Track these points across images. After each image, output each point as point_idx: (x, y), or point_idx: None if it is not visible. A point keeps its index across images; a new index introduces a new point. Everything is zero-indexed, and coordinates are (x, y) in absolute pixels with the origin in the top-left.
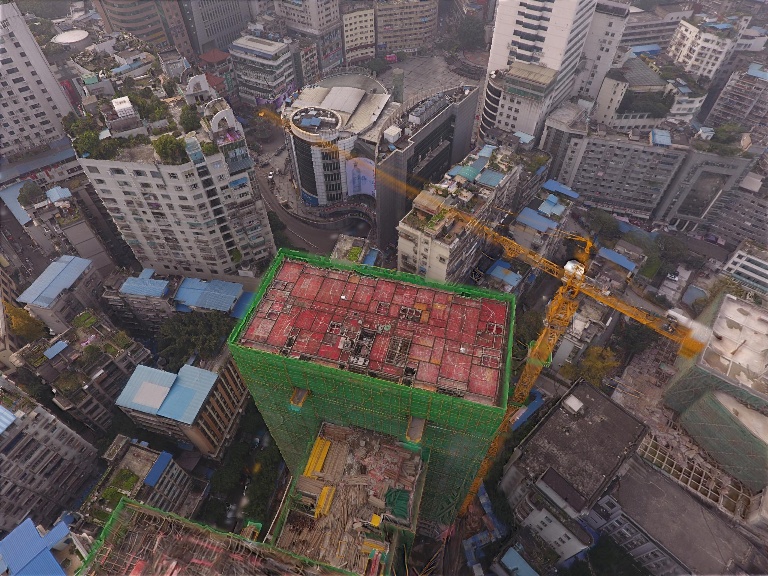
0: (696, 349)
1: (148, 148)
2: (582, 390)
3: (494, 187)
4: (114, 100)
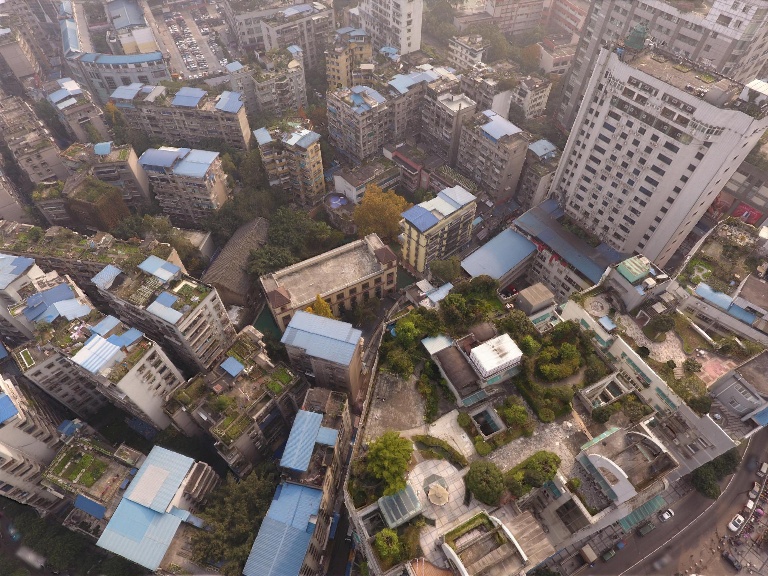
0: None
1: (416, 417)
2: None
3: None
4: (506, 337)
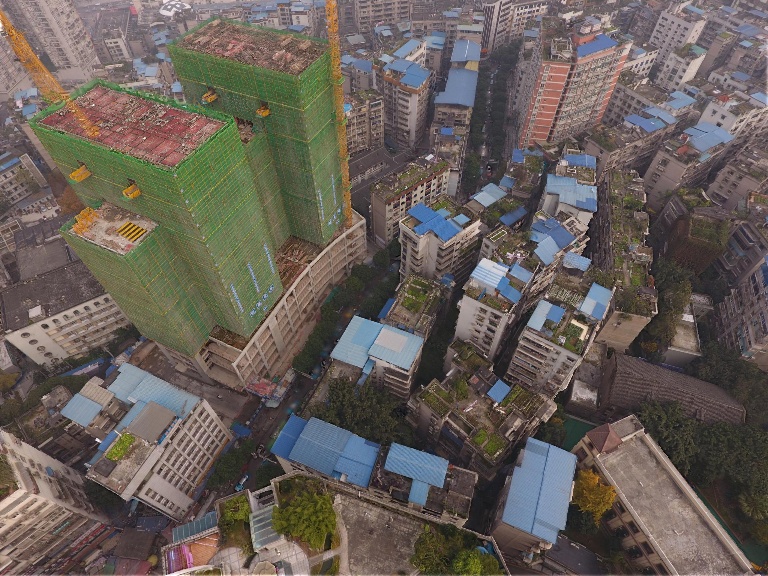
0: None
1: (361, 565)
2: (17, 326)
3: None
4: None
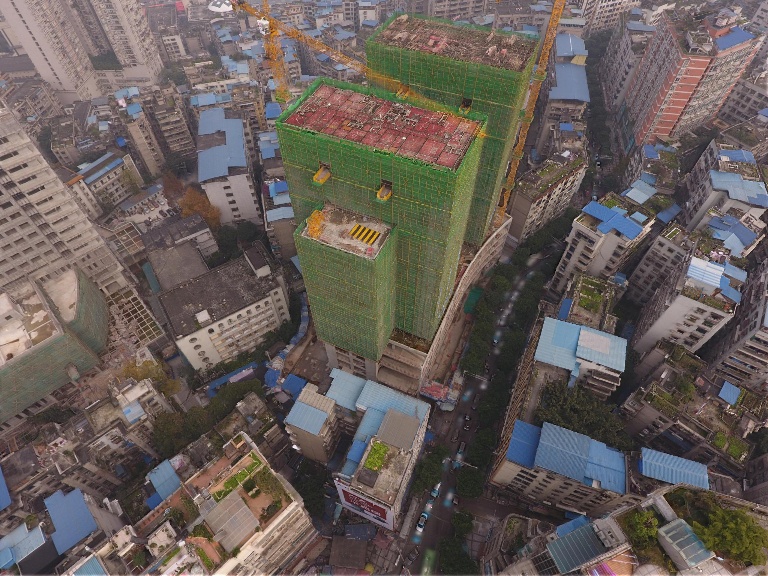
0: (44, 351)
1: None
2: (185, 331)
3: (97, 559)
4: None
